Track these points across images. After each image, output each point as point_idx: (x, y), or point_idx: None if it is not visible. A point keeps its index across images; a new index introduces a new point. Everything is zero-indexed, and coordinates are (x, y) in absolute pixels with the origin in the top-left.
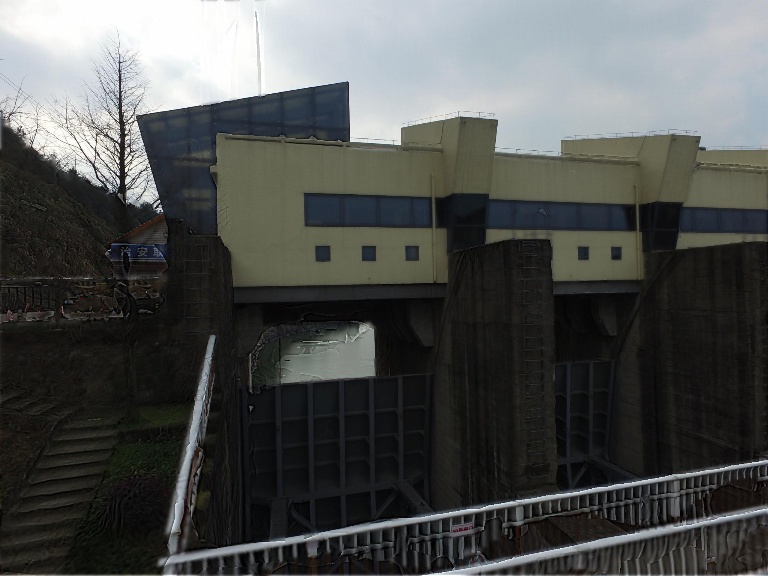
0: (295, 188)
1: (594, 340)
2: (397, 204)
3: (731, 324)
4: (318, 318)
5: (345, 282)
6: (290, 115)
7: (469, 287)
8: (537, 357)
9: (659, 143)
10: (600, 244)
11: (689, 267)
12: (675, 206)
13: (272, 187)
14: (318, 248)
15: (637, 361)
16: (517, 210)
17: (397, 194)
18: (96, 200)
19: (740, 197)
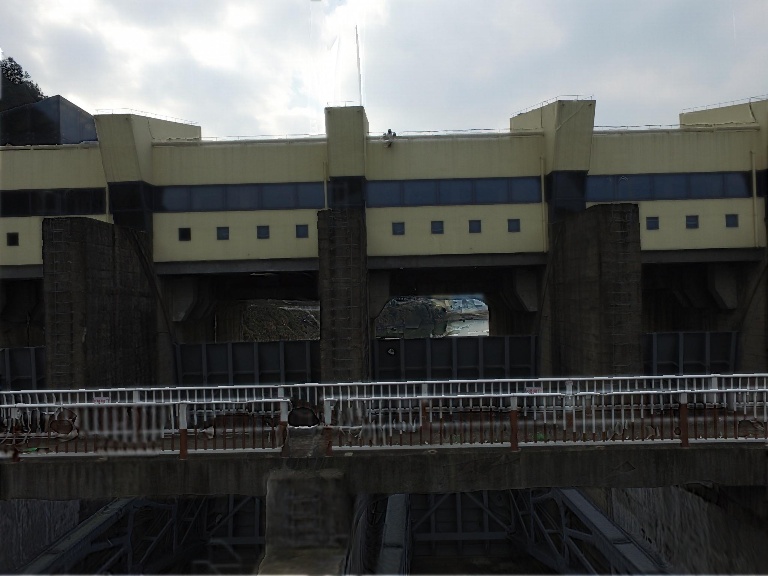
0: None
1: None
2: (80, 195)
3: None
4: None
5: (31, 262)
6: (20, 128)
7: None
8: (66, 320)
9: None
10: (283, 223)
11: None
12: (354, 180)
13: None
14: (10, 235)
15: None
16: (197, 194)
17: (77, 186)
18: None
19: (466, 165)
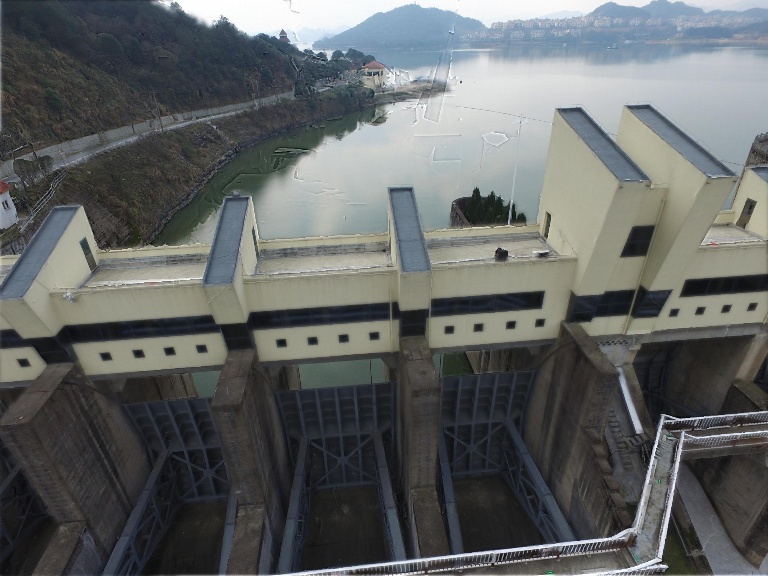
0: None
1: None
2: None
3: None
4: None
5: None
6: None
7: None
8: None
9: None
10: (5, 358)
11: None
12: (48, 338)
13: None
14: None
15: None
16: None
17: None
18: (13, 7)
19: (150, 310)
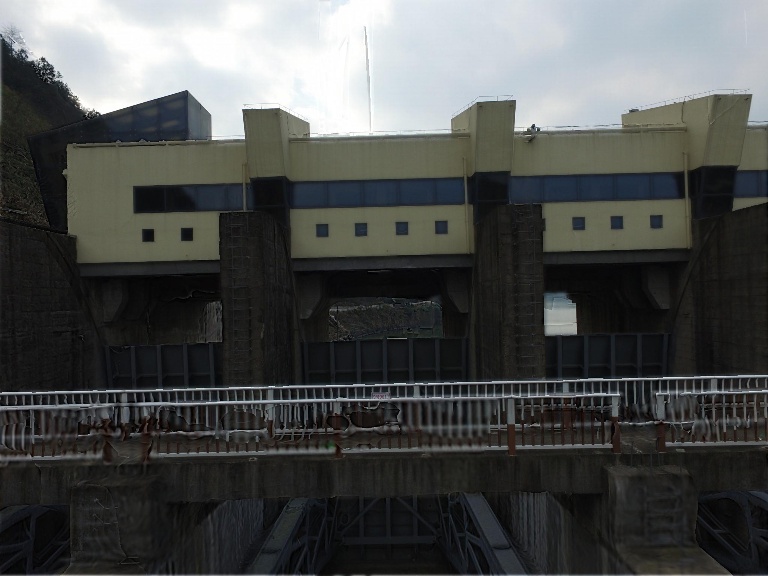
0: (127, 183)
1: (463, 319)
2: (215, 191)
3: (496, 293)
4: (204, 295)
5: (167, 259)
6: (145, 123)
7: None
8: (244, 316)
9: (473, 112)
10: (422, 219)
11: (485, 237)
12: (500, 175)
13: (109, 183)
14: (145, 231)
15: (474, 337)
16: (333, 190)
17: (213, 182)
18: None
19: (607, 161)
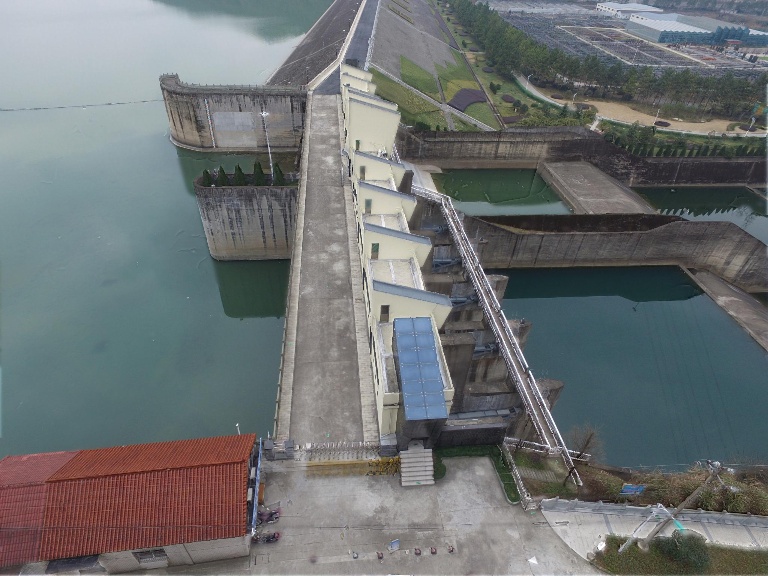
0: None
1: None
2: None
3: None
4: None
5: None
6: None
7: (446, 355)
8: None
9: None
10: None
11: None
12: None
13: None
14: None
15: None
16: None
17: None
18: None
19: None
